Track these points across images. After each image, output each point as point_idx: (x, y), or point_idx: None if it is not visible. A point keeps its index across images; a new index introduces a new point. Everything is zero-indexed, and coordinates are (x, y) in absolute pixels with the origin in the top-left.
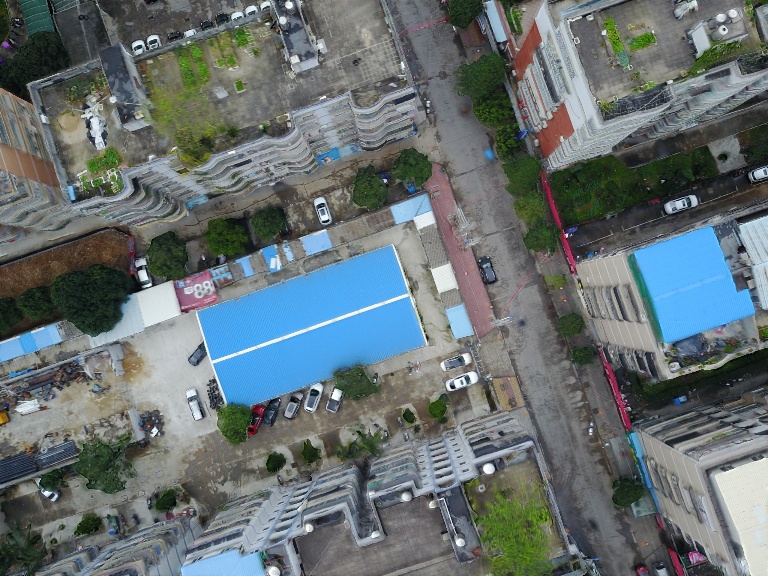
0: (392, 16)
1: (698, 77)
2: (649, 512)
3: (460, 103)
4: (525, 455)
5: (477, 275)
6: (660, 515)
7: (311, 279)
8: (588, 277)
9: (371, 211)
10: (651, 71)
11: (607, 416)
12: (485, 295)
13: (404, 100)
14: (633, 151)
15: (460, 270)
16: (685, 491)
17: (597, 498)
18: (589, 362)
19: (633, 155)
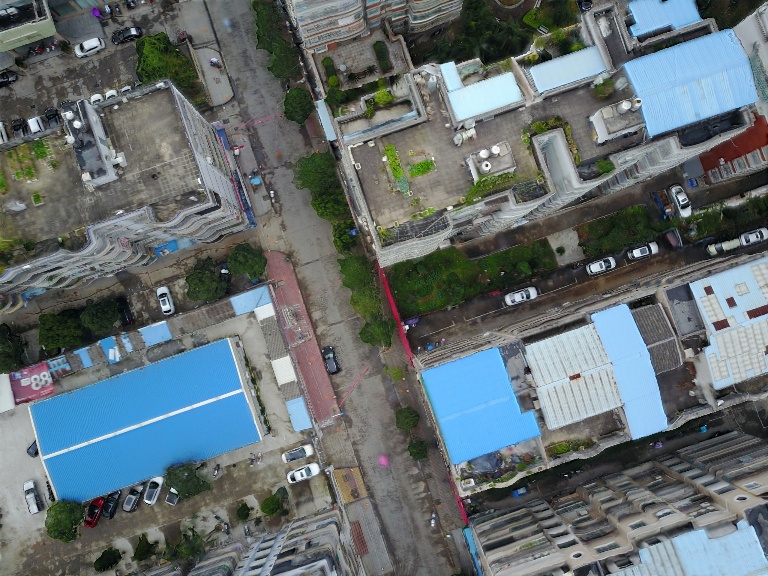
0: (239, 105)
1: (476, 204)
2: None
3: (306, 193)
4: (318, 574)
5: (321, 365)
6: None
7: (145, 373)
8: None
9: (210, 303)
10: (431, 197)
11: (448, 507)
12: (328, 385)
13: (210, 211)
14: (474, 243)
15: (304, 360)
16: None
17: None
18: (424, 457)
19: (474, 246)
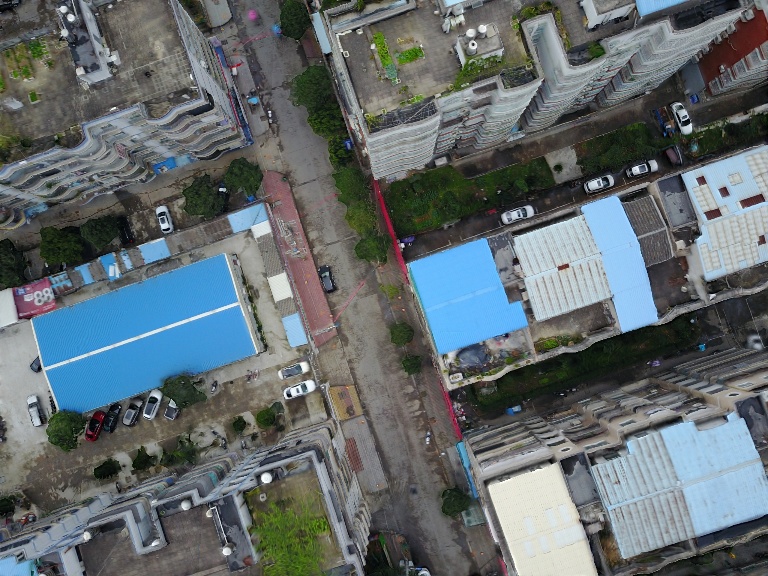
0: (237, 27)
1: (464, 91)
2: (479, 522)
3: (303, 113)
4: (307, 464)
5: (317, 284)
6: (488, 525)
7: (144, 287)
8: (412, 287)
9: (208, 220)
10: (419, 84)
11: (443, 425)
12: (325, 304)
13: (202, 111)
14: (471, 162)
15: (300, 279)
16: (482, 501)
17: (434, 507)
18: (418, 371)
19: (471, 166)
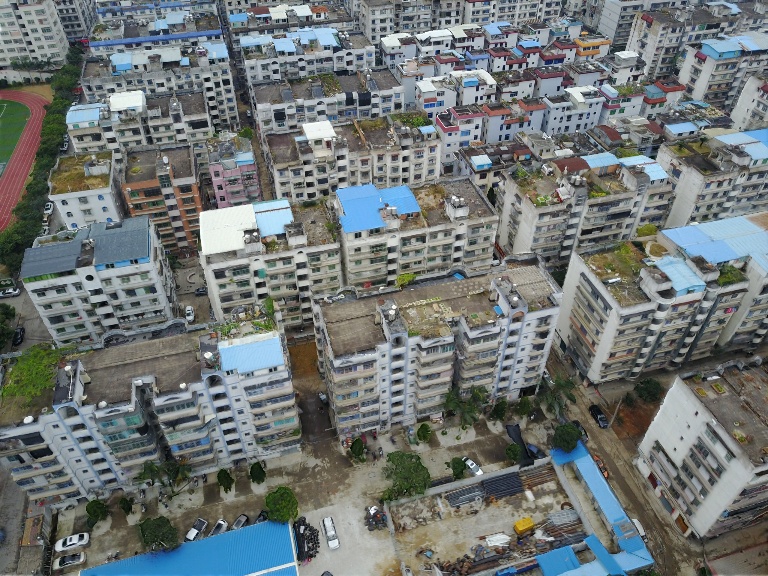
0: None
1: None
2: None
3: None
4: None
5: None
6: None
7: None
8: None
9: None
10: None
11: None
12: None
13: None
14: None
15: None
16: None
17: None
18: None
19: None
